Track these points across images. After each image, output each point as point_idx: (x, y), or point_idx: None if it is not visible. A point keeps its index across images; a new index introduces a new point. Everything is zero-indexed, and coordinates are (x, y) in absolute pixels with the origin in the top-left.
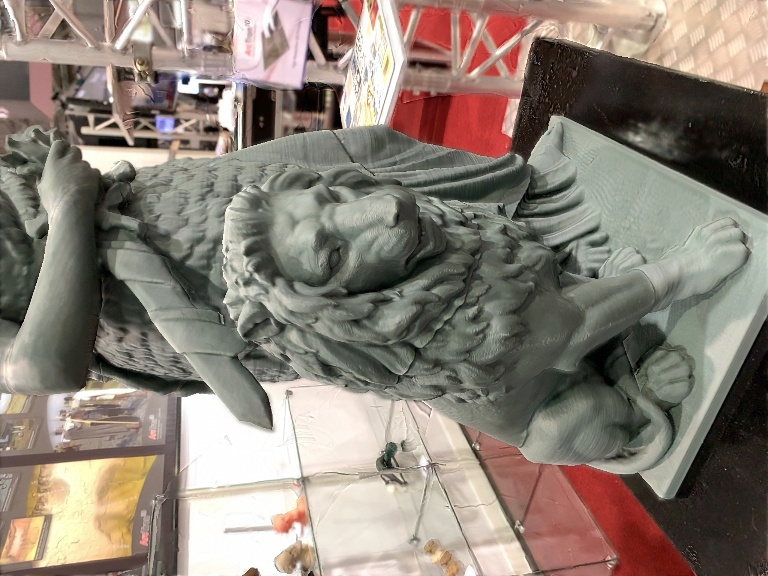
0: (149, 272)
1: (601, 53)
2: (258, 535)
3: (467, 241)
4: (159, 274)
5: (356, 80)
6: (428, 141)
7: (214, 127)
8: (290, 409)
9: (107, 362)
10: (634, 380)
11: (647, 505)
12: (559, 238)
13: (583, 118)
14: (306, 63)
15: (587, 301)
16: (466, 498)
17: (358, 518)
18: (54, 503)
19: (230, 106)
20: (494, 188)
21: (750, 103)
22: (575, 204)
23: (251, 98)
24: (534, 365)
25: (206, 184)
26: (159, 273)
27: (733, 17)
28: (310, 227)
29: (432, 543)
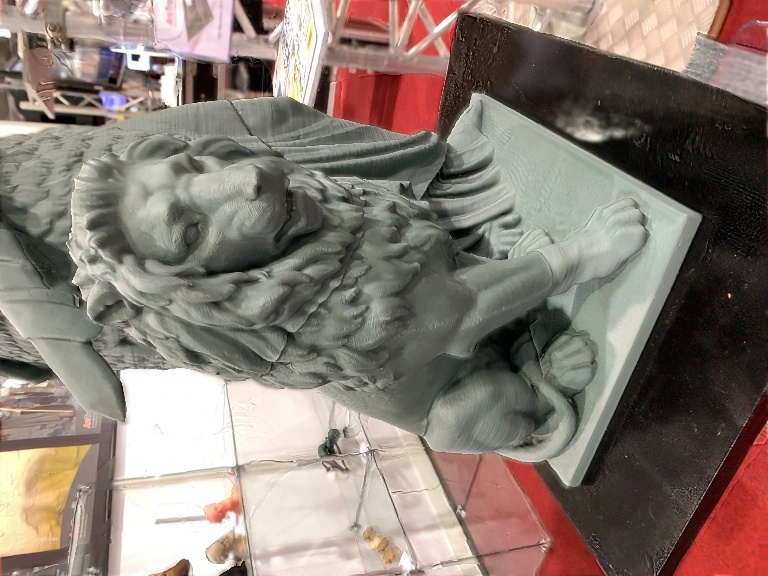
0: None
1: (520, 28)
2: (196, 525)
3: (347, 218)
4: (6, 251)
5: (285, 54)
6: (378, 124)
7: (157, 104)
8: (228, 396)
9: None
10: (539, 366)
11: (556, 493)
12: (472, 219)
13: (503, 96)
14: (232, 35)
15: (480, 284)
16: (410, 483)
17: (300, 505)
18: None
19: (172, 83)
20: (404, 166)
21: (654, 80)
22: (491, 185)
23: (191, 74)
24: (423, 351)
25: (74, 153)
26: (7, 250)
27: (665, 1)
28: (163, 199)
29: (371, 530)
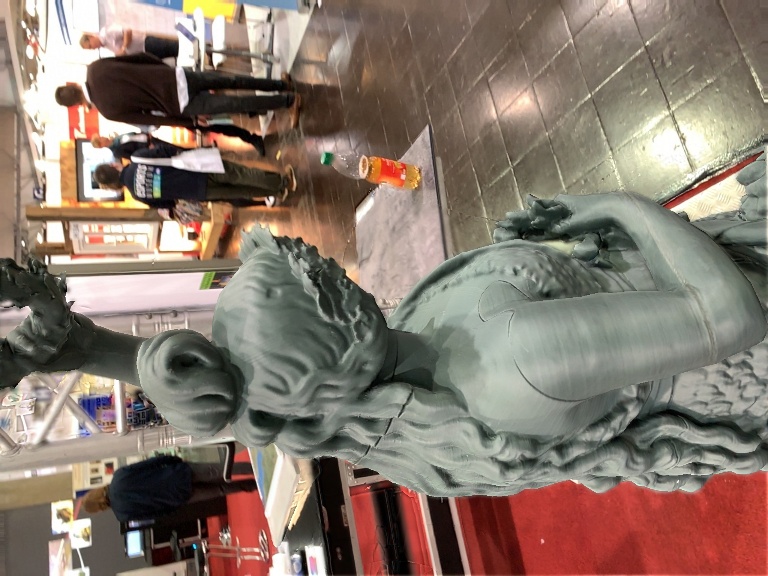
0: None
1: None
2: None
3: None
4: None
5: None
6: (493, 537)
7: None
8: None
9: (682, 413)
10: None
11: None
12: None
13: None
14: None
15: None
16: None
17: None
18: None
19: (282, 569)
20: None
21: None
22: None
23: None
24: None
25: None
26: None
27: None
28: None
29: None
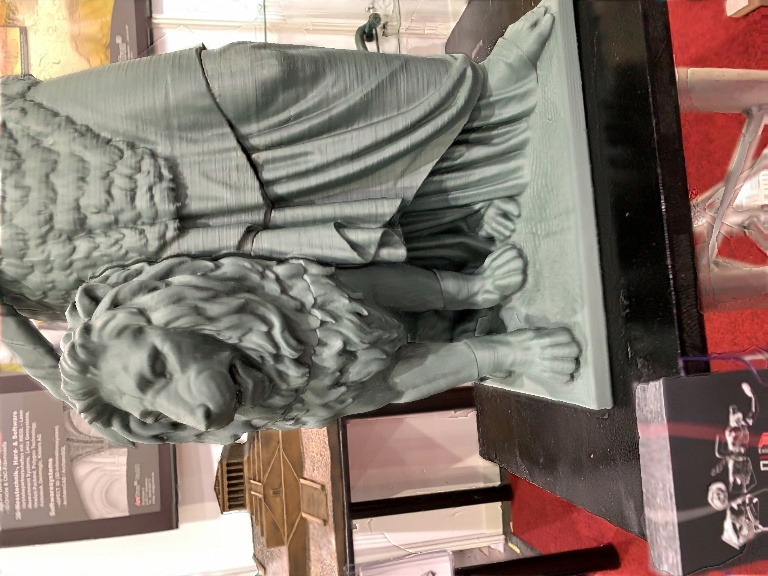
0: (7, 334)
1: None
2: None
3: (292, 384)
4: (17, 336)
5: None
6: None
7: None
8: None
9: None
10: None
11: None
12: (471, 198)
13: (582, 27)
14: None
15: (409, 386)
16: None
17: None
18: (24, 13)
19: None
20: (409, 151)
21: (662, 282)
22: (513, 150)
23: None
24: None
25: (44, 219)
26: (17, 335)
27: None
28: (135, 406)
29: None
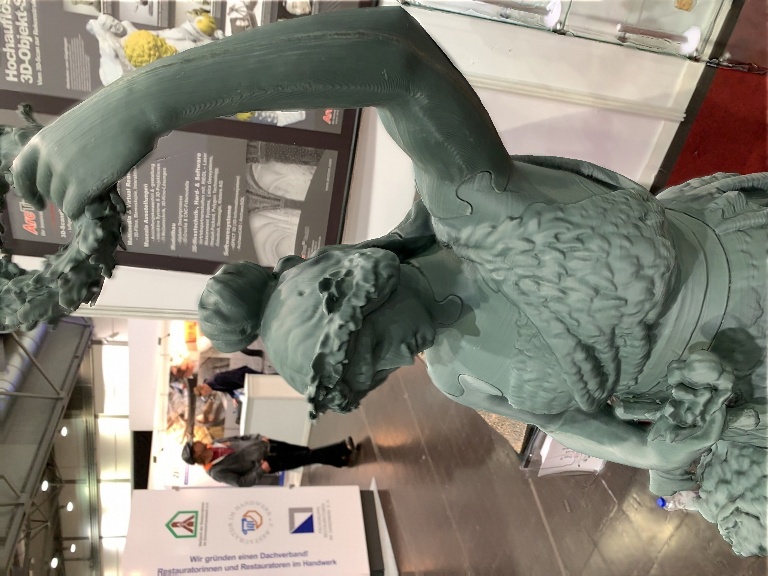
0: None
1: None
2: None
3: None
4: None
5: None
6: None
7: None
8: None
9: None
10: None
11: None
12: None
13: None
14: None
15: None
16: None
17: None
18: None
19: None
20: None
21: None
22: None
23: None
24: None
25: None
26: None
27: None
28: None
29: None
